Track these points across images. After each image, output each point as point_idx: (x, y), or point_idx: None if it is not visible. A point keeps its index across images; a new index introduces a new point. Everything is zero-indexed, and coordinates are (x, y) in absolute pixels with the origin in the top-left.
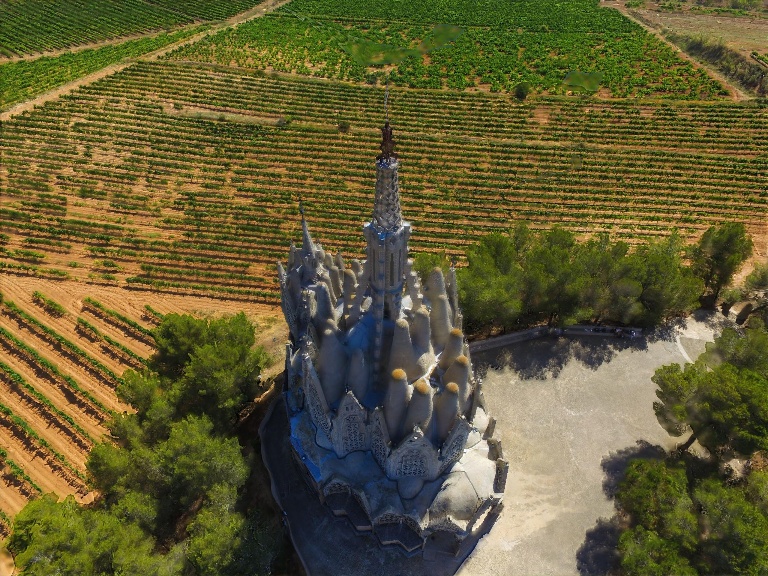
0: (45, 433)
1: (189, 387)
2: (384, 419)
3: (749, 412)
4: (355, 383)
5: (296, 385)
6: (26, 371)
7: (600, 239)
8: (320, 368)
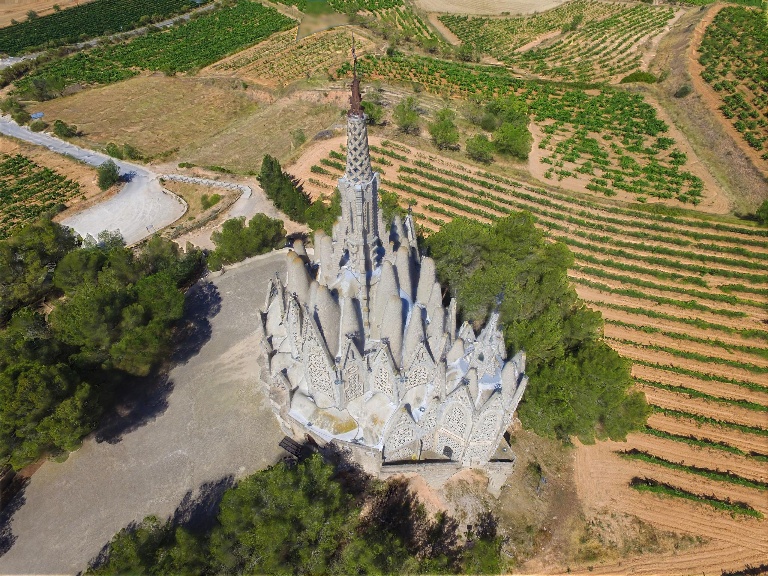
0: (667, 360)
1: None
2: None
3: None
4: None
5: None
6: (762, 402)
7: None
8: None
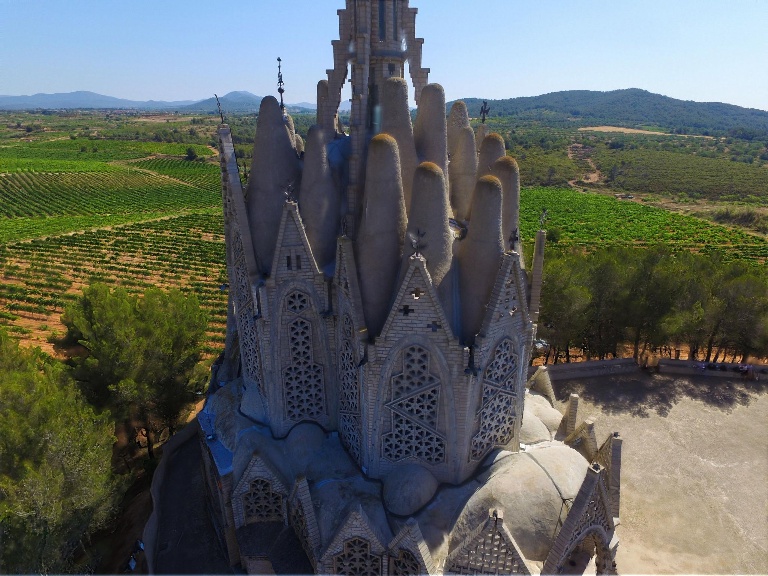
0: None
1: (80, 366)
2: (355, 266)
3: None
4: (308, 207)
5: (234, 343)
6: None
7: None
8: (250, 181)
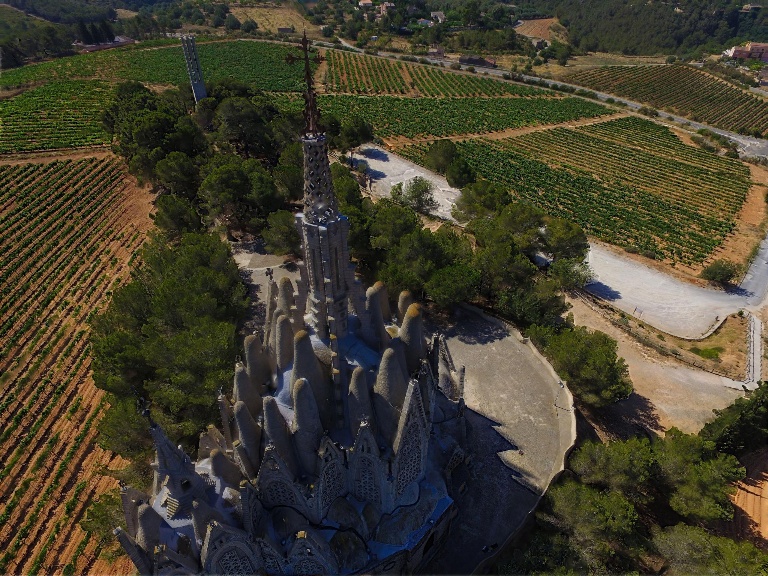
0: None
1: None
2: None
3: (355, 217)
4: None
5: (343, 546)
6: None
7: (133, 277)
8: None
